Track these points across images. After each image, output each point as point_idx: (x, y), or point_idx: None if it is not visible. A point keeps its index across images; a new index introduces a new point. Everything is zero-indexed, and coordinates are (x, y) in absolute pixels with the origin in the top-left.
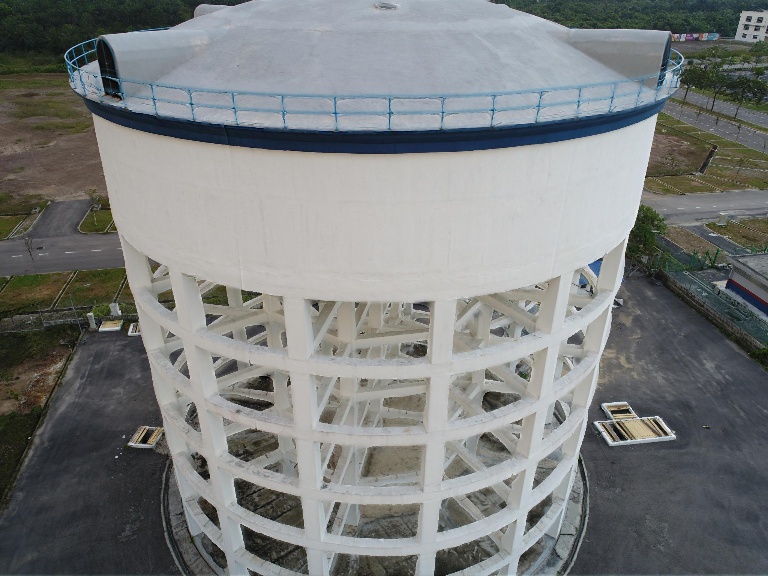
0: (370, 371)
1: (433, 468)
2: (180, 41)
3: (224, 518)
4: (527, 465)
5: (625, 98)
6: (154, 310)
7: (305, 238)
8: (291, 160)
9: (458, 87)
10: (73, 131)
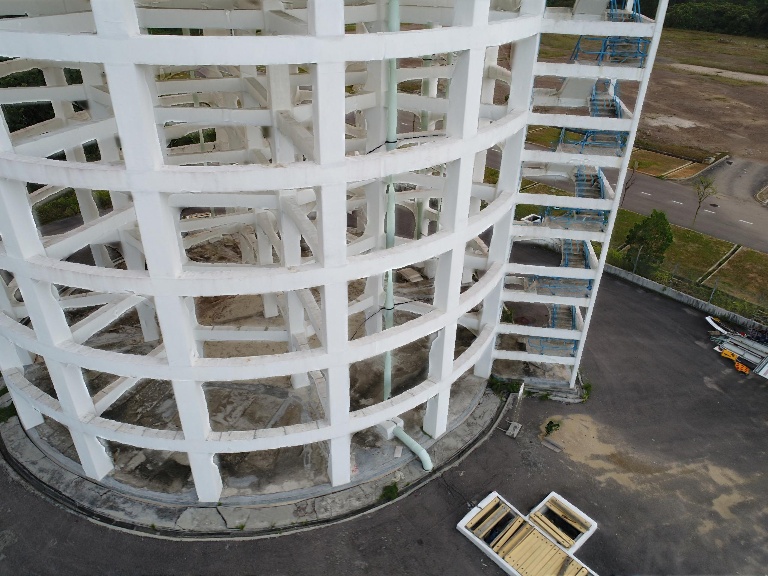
0: None
1: None
2: None
3: None
4: (11, 266)
5: None
6: None
7: None
8: None
9: None
10: (542, 56)
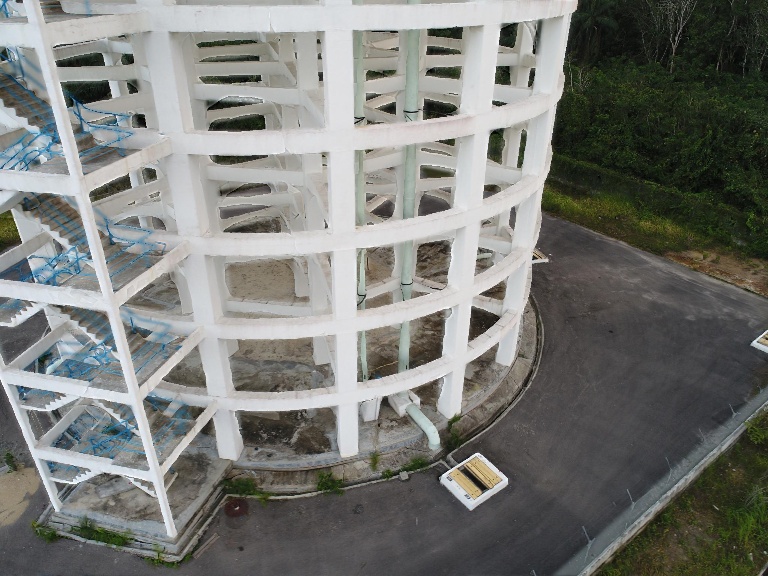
0: None
1: None
2: None
3: None
4: None
5: None
6: None
7: None
8: None
9: None
10: None
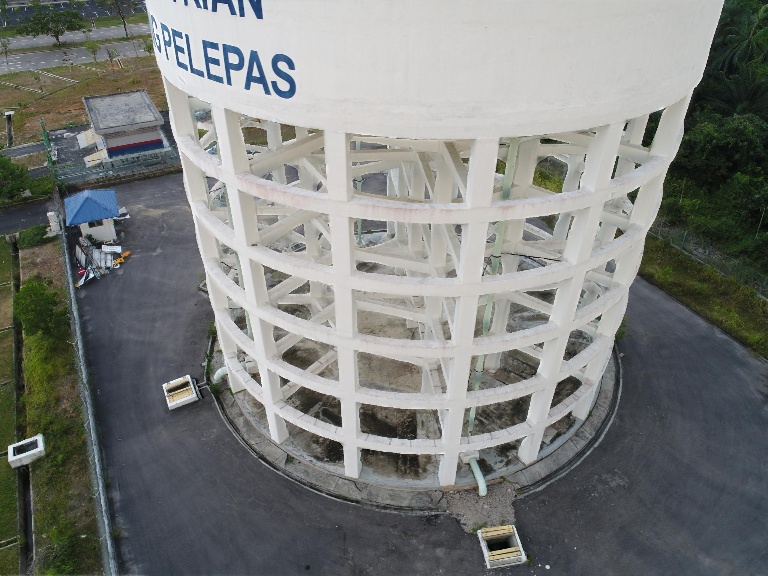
0: None
1: None
2: None
3: None
4: None
5: None
6: None
7: None
8: None
9: None
10: None
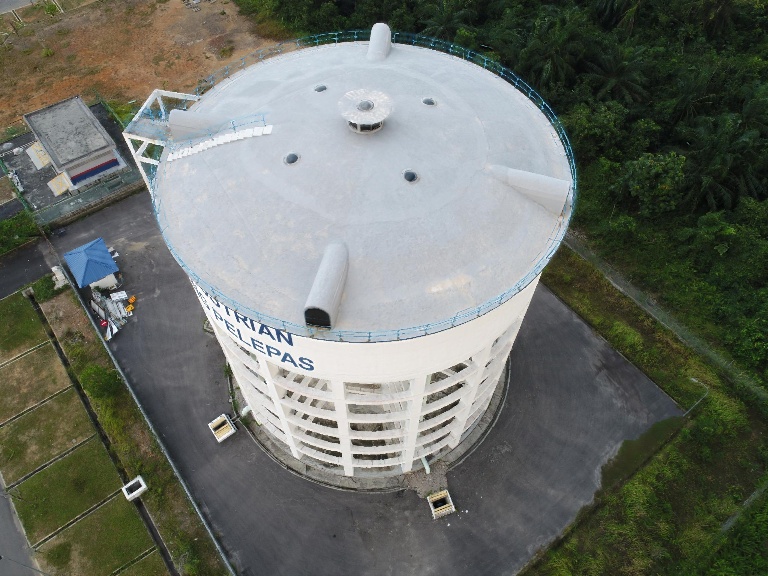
0: None
1: None
2: None
3: None
4: None
5: (421, 52)
6: None
7: None
8: None
9: (482, 84)
10: None
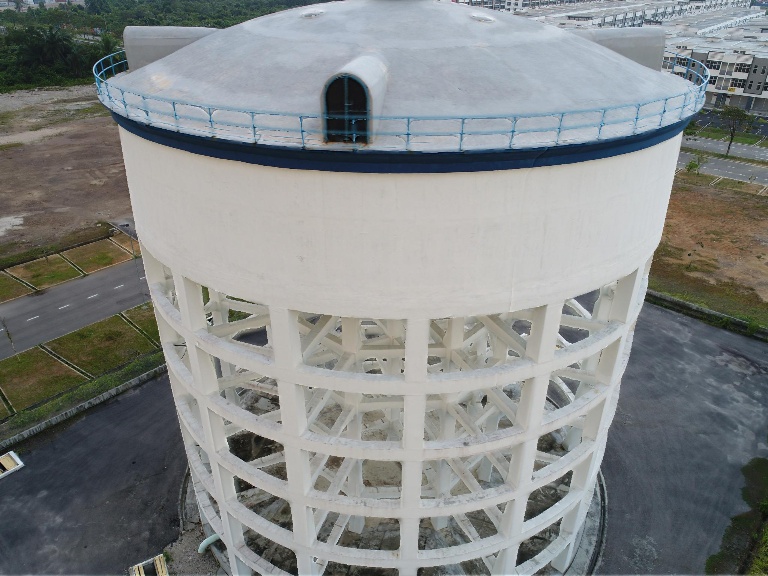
0: (594, 348)
1: (604, 416)
2: (379, 70)
3: (411, 573)
4: None
5: None
6: (353, 380)
7: (577, 241)
8: (581, 170)
9: (630, 85)
10: None
